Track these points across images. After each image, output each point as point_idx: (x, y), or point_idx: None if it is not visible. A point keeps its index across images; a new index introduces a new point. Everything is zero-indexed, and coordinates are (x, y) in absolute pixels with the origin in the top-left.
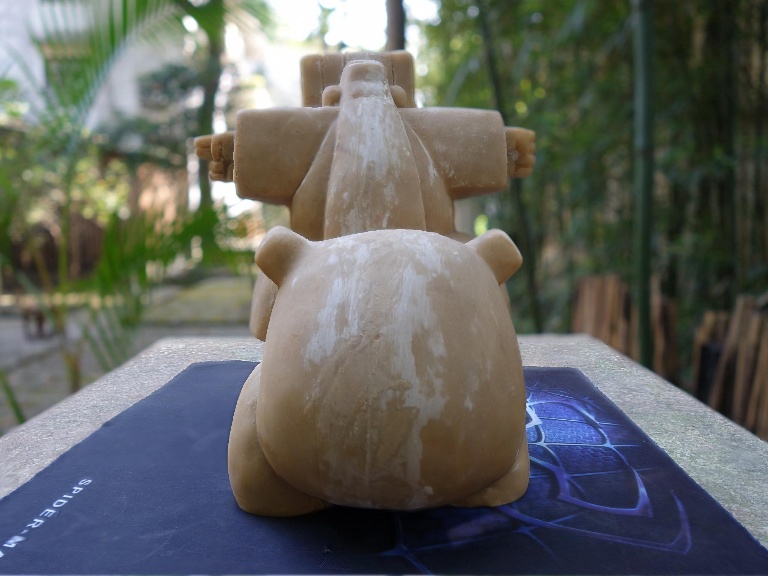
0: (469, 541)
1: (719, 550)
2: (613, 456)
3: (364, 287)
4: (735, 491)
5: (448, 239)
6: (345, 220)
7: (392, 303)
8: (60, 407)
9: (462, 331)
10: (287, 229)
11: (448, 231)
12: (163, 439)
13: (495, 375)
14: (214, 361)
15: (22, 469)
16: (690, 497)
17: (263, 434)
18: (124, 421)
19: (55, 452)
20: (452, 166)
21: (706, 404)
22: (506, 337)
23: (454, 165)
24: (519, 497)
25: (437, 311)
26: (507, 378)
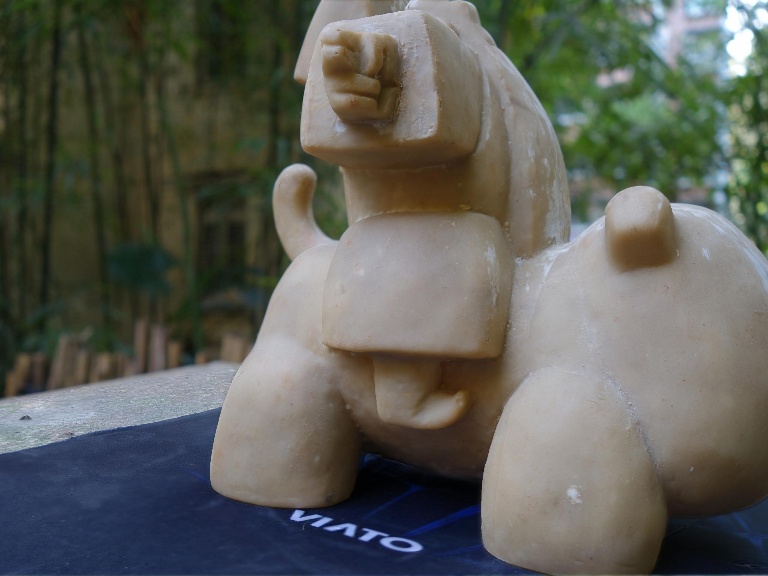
0: None
1: None
2: None
3: None
4: None
5: None
6: (551, 192)
7: None
8: None
9: None
10: None
11: None
12: None
13: None
14: None
15: None
16: None
17: (728, 448)
18: None
19: None
20: None
21: None
22: None
23: None
24: None
25: None
26: None
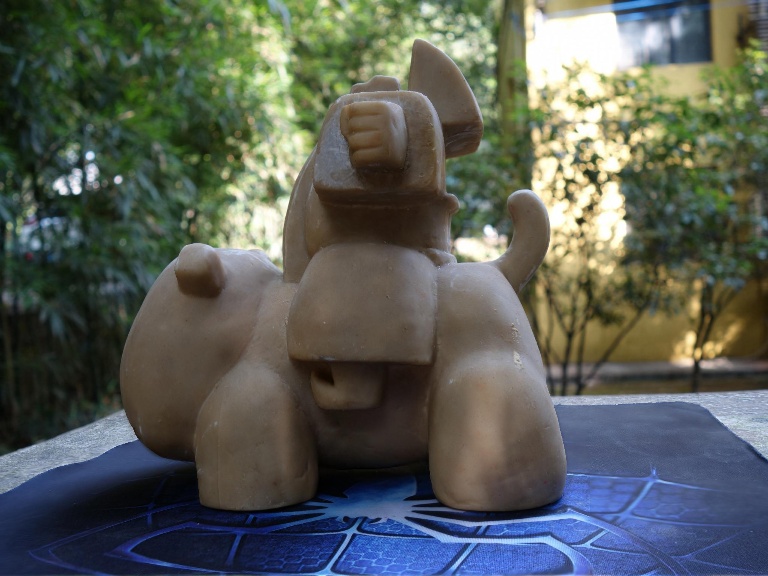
0: None
1: (10, 568)
2: (280, 567)
3: None
4: None
5: None
6: None
7: None
8: None
9: None
10: None
11: (323, 243)
12: None
13: None
14: None
15: None
16: None
17: None
18: None
19: None
20: None
21: None
22: None
23: None
24: (204, 505)
25: None
26: (127, 360)
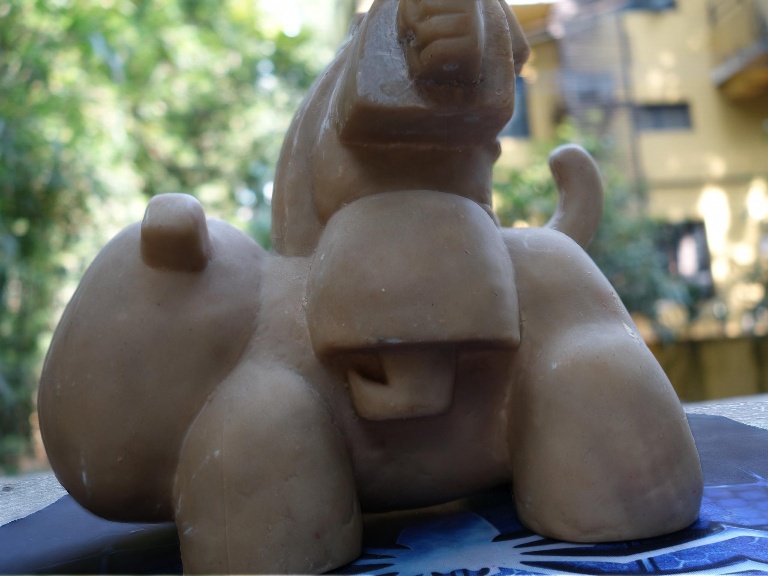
0: (101, 574)
1: None
2: None
3: None
4: None
5: None
6: None
7: None
8: None
9: None
10: None
11: (347, 197)
12: None
13: (50, 367)
14: None
15: None
16: None
17: None
18: None
19: None
20: None
21: None
22: (76, 326)
23: (338, 104)
24: None
25: None
26: (58, 373)
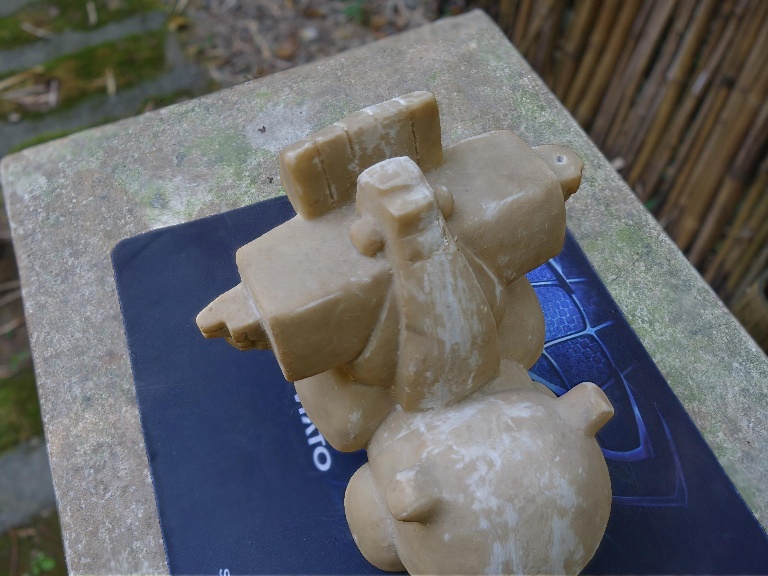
0: None
1: (704, 491)
2: (600, 353)
3: (522, 546)
4: (691, 377)
5: (569, 452)
6: (430, 390)
7: (547, 550)
8: (53, 416)
9: (592, 529)
10: (420, 491)
11: None
12: (229, 467)
13: None
14: (130, 238)
15: (141, 565)
16: (669, 411)
17: None
18: (161, 441)
19: (142, 522)
20: (514, 270)
21: (636, 194)
22: None
23: (516, 268)
24: None
25: (578, 534)
26: None
